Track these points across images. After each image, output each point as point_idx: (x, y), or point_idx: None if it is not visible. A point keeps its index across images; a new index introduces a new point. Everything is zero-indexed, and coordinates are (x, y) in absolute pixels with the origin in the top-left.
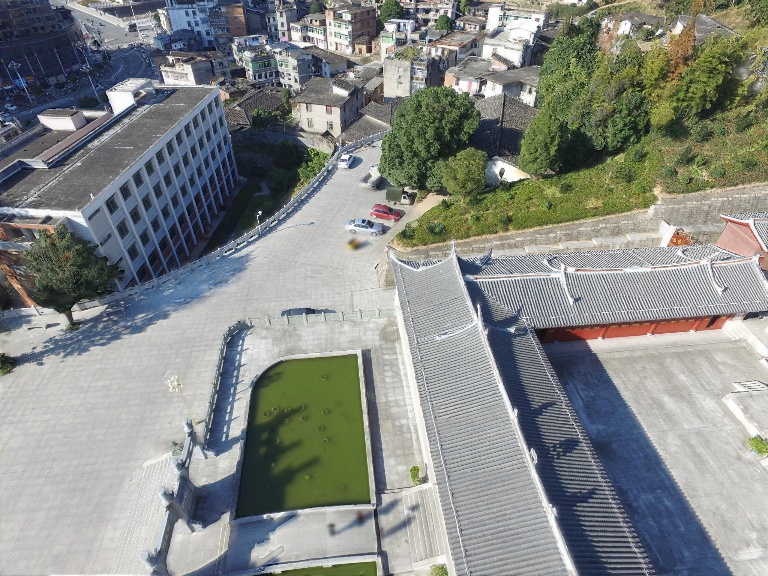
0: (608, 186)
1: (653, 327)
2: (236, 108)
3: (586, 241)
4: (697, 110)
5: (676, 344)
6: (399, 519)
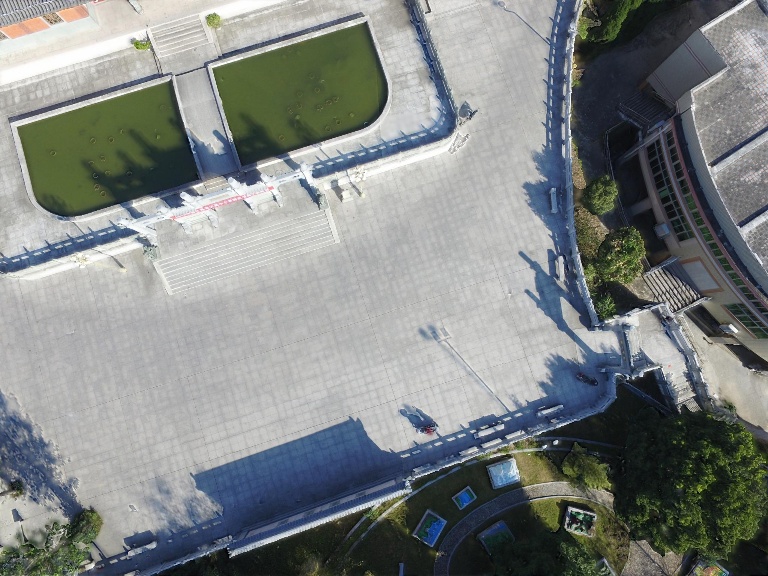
0: None
1: None
2: None
3: None
4: None
5: None
6: (180, 57)
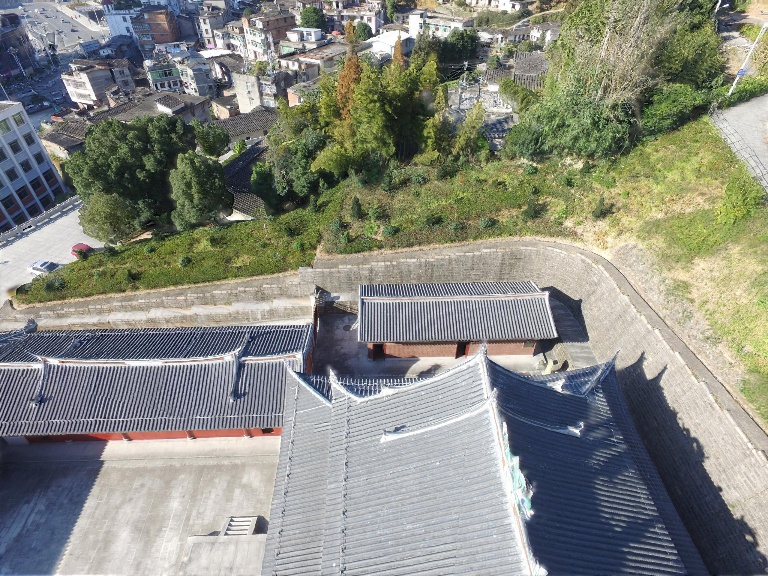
0: (269, 240)
1: (186, 431)
2: (87, 122)
3: (224, 306)
4: (387, 153)
5: (211, 454)
6: None
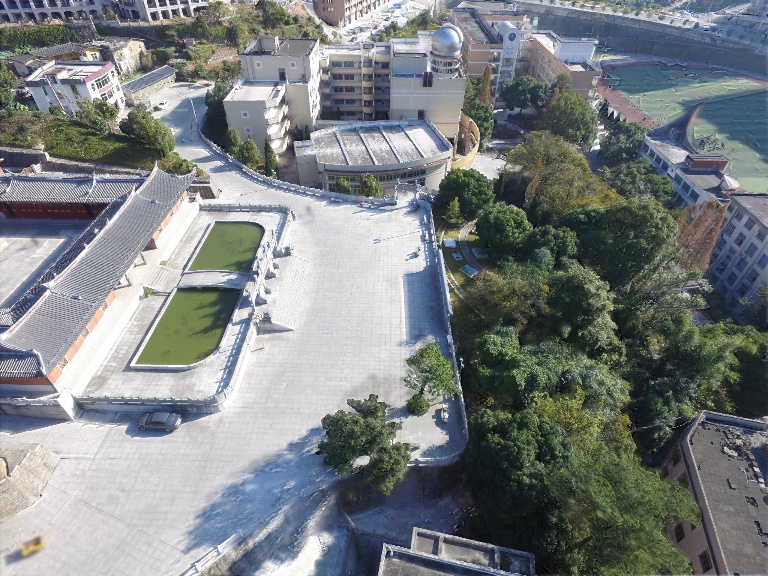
0: None
1: None
2: None
3: None
4: None
5: None
6: (168, 284)
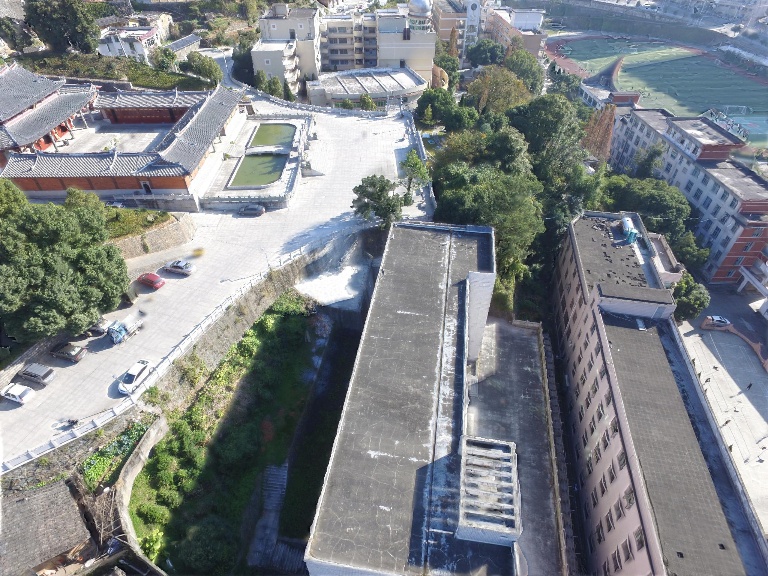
0: None
1: None
2: None
3: None
4: None
5: None
6: (238, 153)
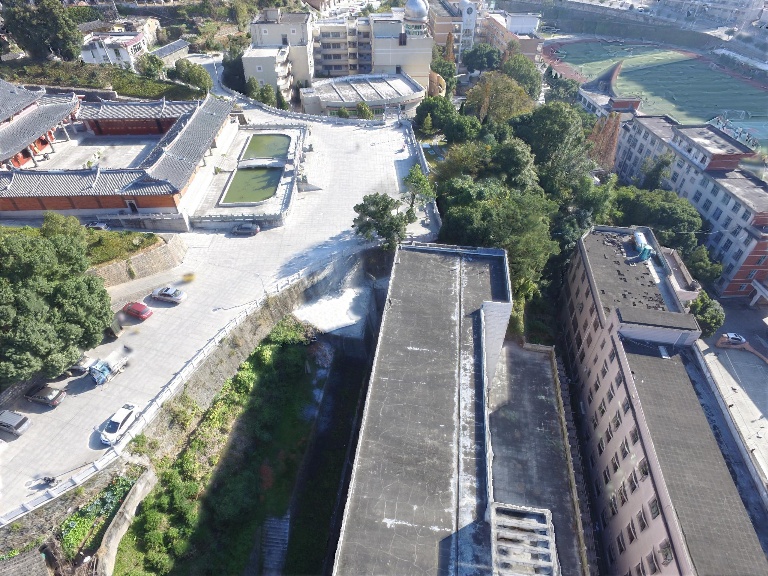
0: None
1: None
2: None
3: None
4: None
5: None
6: None
